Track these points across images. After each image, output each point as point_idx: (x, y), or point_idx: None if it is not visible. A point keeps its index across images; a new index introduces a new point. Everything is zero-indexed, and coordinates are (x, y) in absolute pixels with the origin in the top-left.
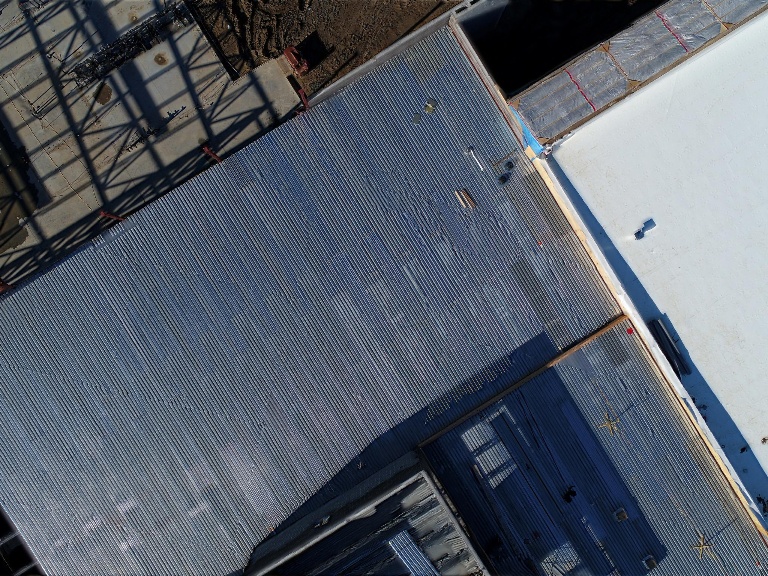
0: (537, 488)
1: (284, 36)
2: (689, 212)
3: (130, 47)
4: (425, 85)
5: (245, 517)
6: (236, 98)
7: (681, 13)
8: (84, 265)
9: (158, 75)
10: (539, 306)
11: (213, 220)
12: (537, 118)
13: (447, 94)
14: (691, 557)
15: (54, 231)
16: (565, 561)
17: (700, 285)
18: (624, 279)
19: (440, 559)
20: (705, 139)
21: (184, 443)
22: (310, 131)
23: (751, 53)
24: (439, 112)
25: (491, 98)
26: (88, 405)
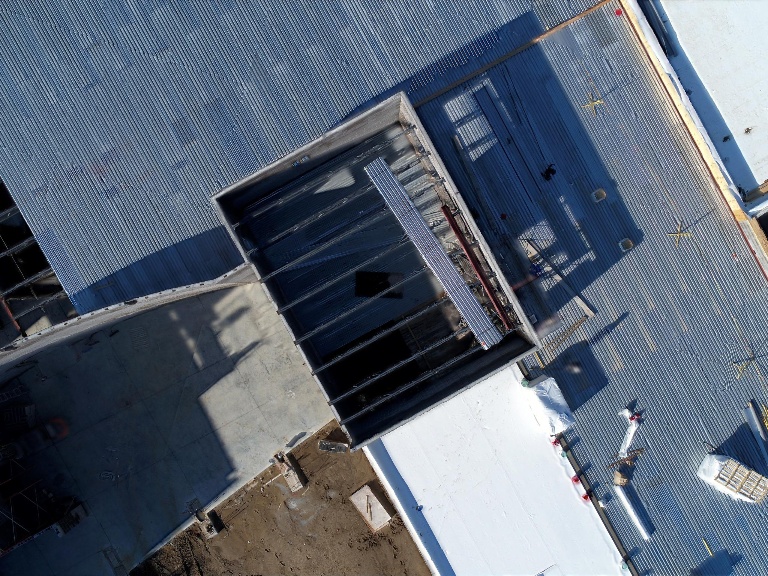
0: (517, 164)
1: None
2: None
3: None
4: None
5: (224, 175)
6: None
7: None
8: None
9: None
10: None
11: None
12: None
13: None
14: (668, 244)
15: None
16: (541, 239)
17: None
18: None
19: None
20: None
21: (167, 98)
22: None
23: None
24: None
25: None
26: (74, 53)
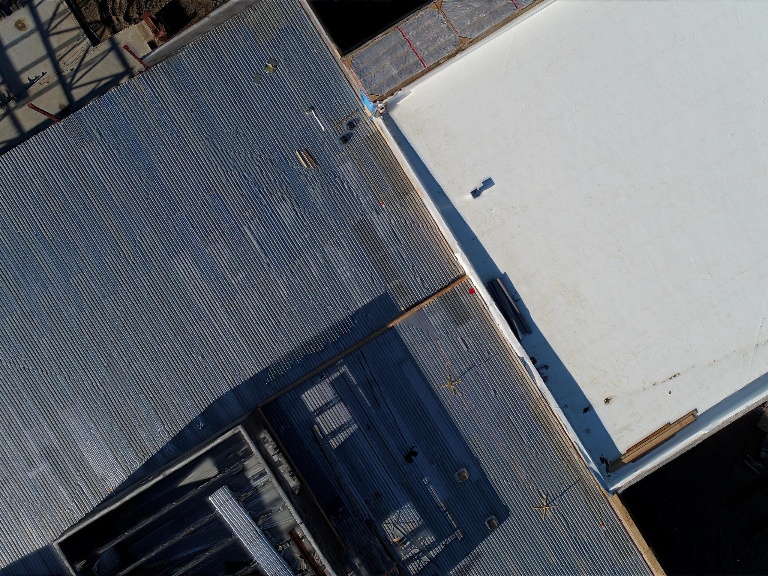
0: (378, 448)
1: (145, 2)
2: (528, 171)
3: None
4: (266, 45)
5: (84, 478)
6: (97, 64)
7: None
8: None
9: (18, 41)
10: (381, 266)
11: (52, 180)
12: (368, 75)
13: (288, 54)
14: (534, 518)
15: None
16: (407, 522)
17: (540, 244)
18: (463, 238)
19: (262, 515)
20: (543, 98)
21: (22, 403)
22: (150, 91)
23: (588, 12)
24: (280, 72)
25: (332, 58)
26: None
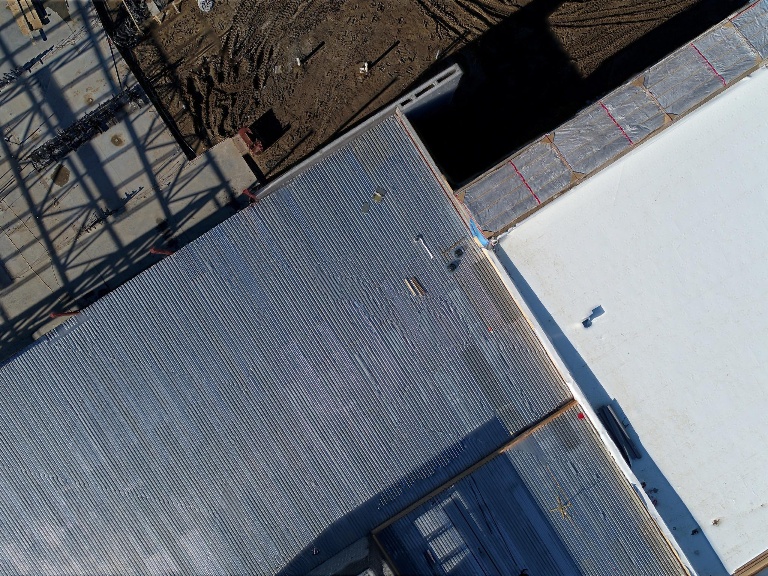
0: (490, 572)
1: (240, 115)
2: (637, 298)
3: (87, 129)
4: (374, 174)
5: None
6: (193, 178)
7: (626, 103)
8: (39, 359)
9: (115, 156)
10: (490, 391)
11: (165, 312)
12: (483, 211)
13: (396, 183)
14: None
15: (16, 312)
16: None
17: (649, 370)
18: (573, 366)
19: None
20: (653, 226)
21: (141, 532)
22: (260, 222)
23: (698, 139)
24: (388, 201)
25: (440, 186)
26: (46, 496)
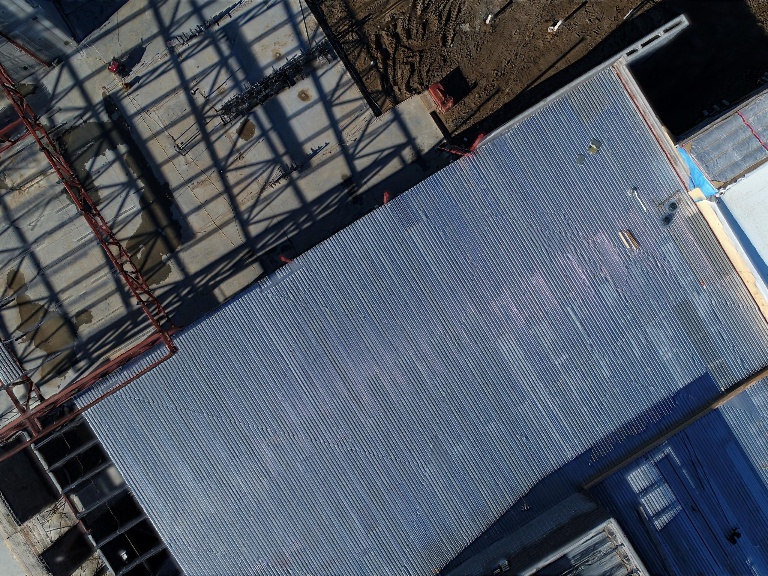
0: (702, 530)
1: (427, 72)
2: None
3: None
4: (589, 126)
5: (410, 559)
6: (379, 134)
7: None
8: (251, 307)
9: (302, 111)
10: (702, 347)
11: (379, 262)
12: (711, 161)
13: (611, 135)
14: None
15: (197, 267)
16: None
17: None
18: None
19: None
20: None
21: (350, 485)
22: (475, 172)
23: None
24: (603, 153)
25: (655, 139)
26: (254, 447)
